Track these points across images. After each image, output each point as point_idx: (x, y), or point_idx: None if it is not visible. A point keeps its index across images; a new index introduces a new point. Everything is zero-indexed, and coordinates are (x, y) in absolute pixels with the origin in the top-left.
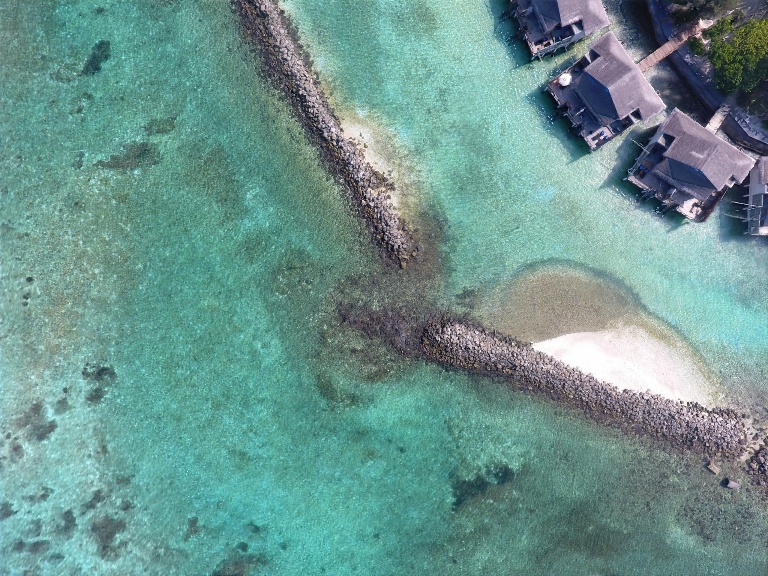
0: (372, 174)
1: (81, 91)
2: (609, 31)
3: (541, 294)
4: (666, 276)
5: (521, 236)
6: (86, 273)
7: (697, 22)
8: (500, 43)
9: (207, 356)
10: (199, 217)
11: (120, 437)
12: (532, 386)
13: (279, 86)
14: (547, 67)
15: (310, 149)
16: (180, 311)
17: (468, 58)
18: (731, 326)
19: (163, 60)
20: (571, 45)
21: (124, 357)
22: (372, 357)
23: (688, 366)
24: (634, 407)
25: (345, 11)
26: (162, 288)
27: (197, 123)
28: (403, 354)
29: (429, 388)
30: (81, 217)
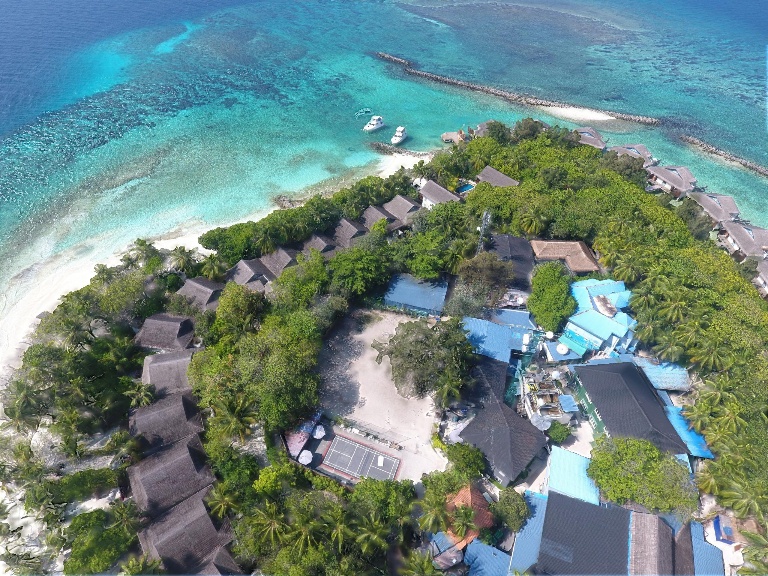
0: None
1: None
2: (646, 166)
3: None
4: None
5: None
6: None
7: None
8: None
9: None
10: None
11: (760, 111)
12: None
13: None
14: None
15: None
16: None
17: None
18: None
19: None
20: None
21: None
22: None
23: None
24: None
25: None
26: None
27: None
28: None
29: None
30: None
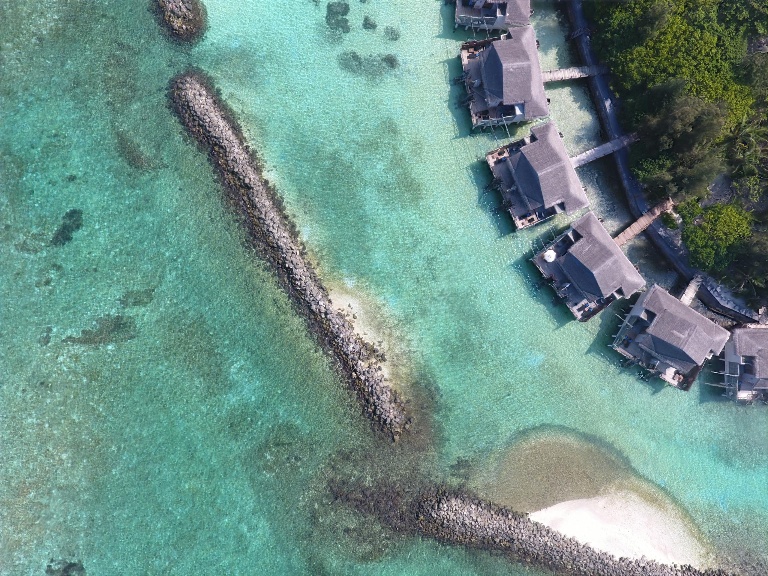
0: (362, 345)
1: (49, 262)
2: (589, 211)
3: (535, 462)
4: (653, 438)
5: (512, 403)
6: (52, 459)
7: (668, 198)
8: (485, 213)
9: (188, 544)
10: (179, 393)
11: None
12: (530, 558)
13: (264, 257)
14: (530, 236)
15: (297, 320)
16: (158, 496)
17: (454, 227)
18: (716, 485)
19: (140, 230)
20: (552, 216)
21: (94, 550)
22: (366, 536)
23: (679, 528)
24: (631, 575)
25: (331, 181)
26: (138, 471)
27: (177, 295)
28: (398, 531)
29: (426, 565)
30: (47, 398)
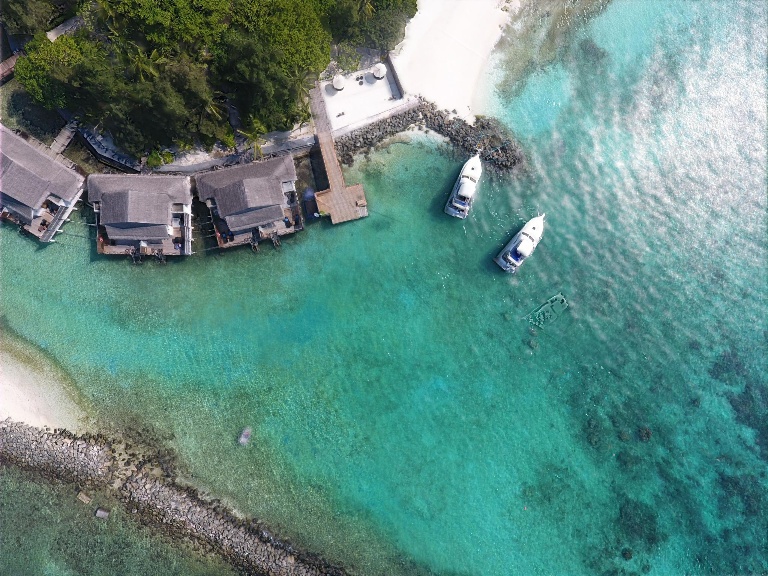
0: None
1: None
2: None
3: None
4: (35, 297)
5: None
6: None
7: None
8: None
9: None
10: None
11: None
12: None
13: None
14: None
15: None
16: None
17: None
18: (106, 348)
19: None
20: None
21: None
22: None
23: (56, 391)
24: None
25: None
26: None
27: None
28: None
29: None
30: None
